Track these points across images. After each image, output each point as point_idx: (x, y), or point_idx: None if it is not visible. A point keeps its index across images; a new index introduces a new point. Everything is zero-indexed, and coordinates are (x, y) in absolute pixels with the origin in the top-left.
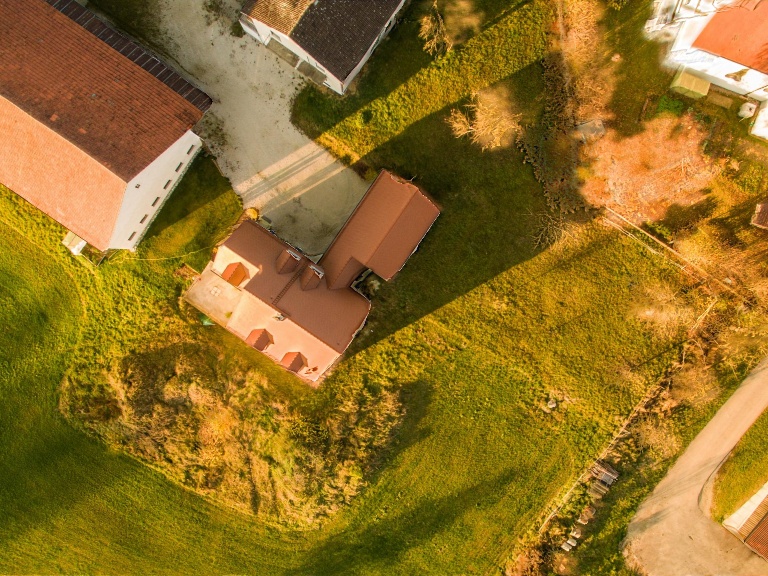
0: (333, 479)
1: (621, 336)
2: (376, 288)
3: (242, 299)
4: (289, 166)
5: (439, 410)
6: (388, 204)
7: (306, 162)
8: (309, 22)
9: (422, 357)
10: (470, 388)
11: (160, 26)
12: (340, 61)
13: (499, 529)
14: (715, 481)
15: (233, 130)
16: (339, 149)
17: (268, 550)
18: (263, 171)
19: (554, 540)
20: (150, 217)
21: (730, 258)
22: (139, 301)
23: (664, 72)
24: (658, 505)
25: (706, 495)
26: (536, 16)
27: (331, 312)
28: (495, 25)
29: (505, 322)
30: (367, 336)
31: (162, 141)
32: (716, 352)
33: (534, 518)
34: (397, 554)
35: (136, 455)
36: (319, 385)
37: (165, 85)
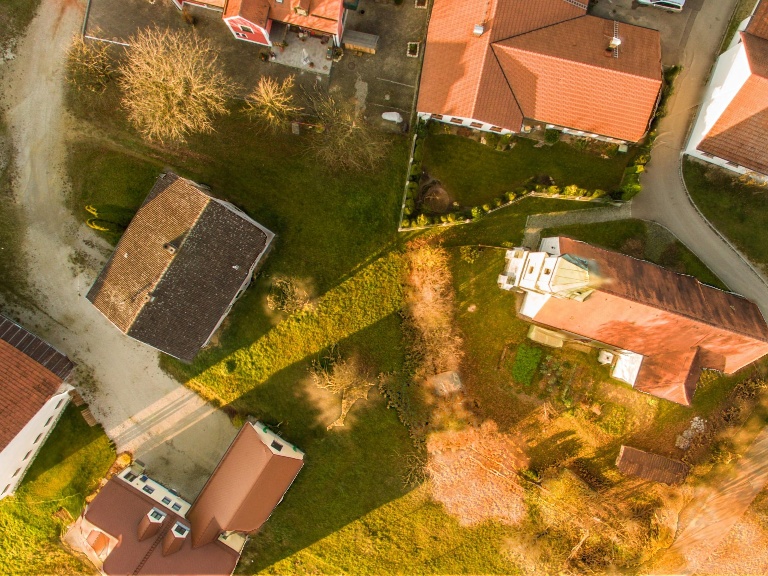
0: None
1: (496, 567)
2: None
3: None
4: (160, 410)
5: None
6: (247, 465)
7: (177, 405)
8: (147, 317)
9: None
10: None
11: (28, 279)
12: (185, 344)
13: None
14: None
15: (103, 377)
16: (208, 393)
17: None
18: (135, 416)
19: None
20: (26, 464)
21: (599, 494)
22: (22, 540)
23: (518, 325)
24: None
25: None
26: (391, 269)
27: None
28: (351, 278)
29: (381, 555)
30: (248, 566)
31: (18, 420)
32: None
33: None
34: None
35: None
36: None
37: (25, 355)
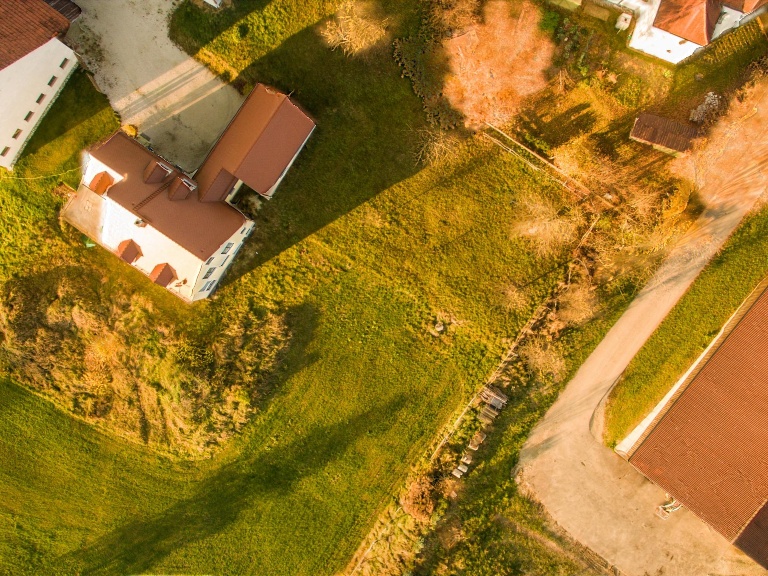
0: (221, 405)
1: (505, 255)
2: (258, 207)
3: (108, 208)
4: (168, 83)
5: (326, 334)
6: (259, 114)
7: (185, 79)
8: None
9: (307, 279)
10: (357, 311)
11: None
12: None
13: (392, 457)
14: (606, 406)
15: (110, 46)
16: (218, 65)
17: (160, 480)
18: (141, 88)
19: (445, 466)
20: (26, 134)
21: (612, 174)
22: (19, 222)
23: None
24: (549, 431)
25: (598, 420)
26: None
27: (199, 222)
28: None
29: (389, 242)
30: (252, 258)
31: (23, 46)
32: (602, 272)
33: (426, 445)
34: (290, 484)
35: (24, 383)
36: (205, 309)
37: None
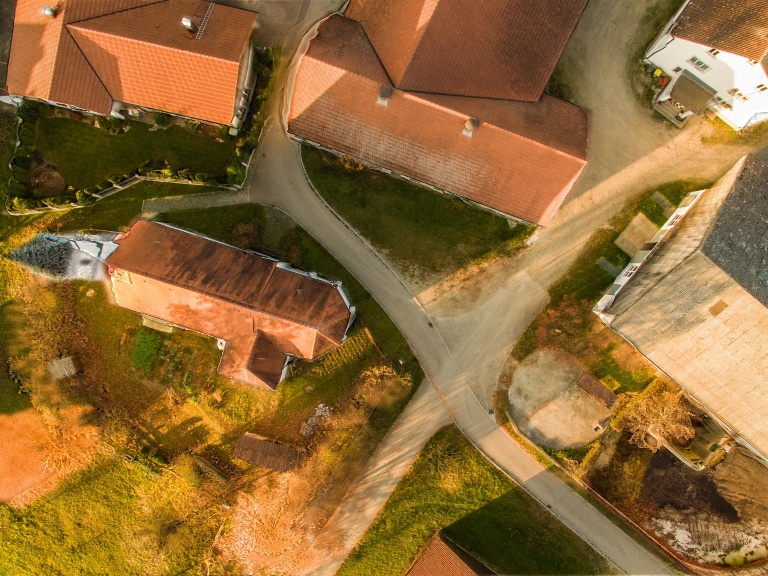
0: None
1: (142, 555)
2: None
3: None
4: None
5: None
6: None
7: None
8: None
9: None
10: None
11: None
12: None
13: None
14: None
15: None
16: None
17: None
18: None
19: None
20: None
21: (233, 481)
22: None
23: None
24: None
25: None
26: (11, 253)
27: None
28: None
29: (29, 541)
30: None
31: None
32: (240, 568)
33: None
34: None
35: None
36: None
37: None
